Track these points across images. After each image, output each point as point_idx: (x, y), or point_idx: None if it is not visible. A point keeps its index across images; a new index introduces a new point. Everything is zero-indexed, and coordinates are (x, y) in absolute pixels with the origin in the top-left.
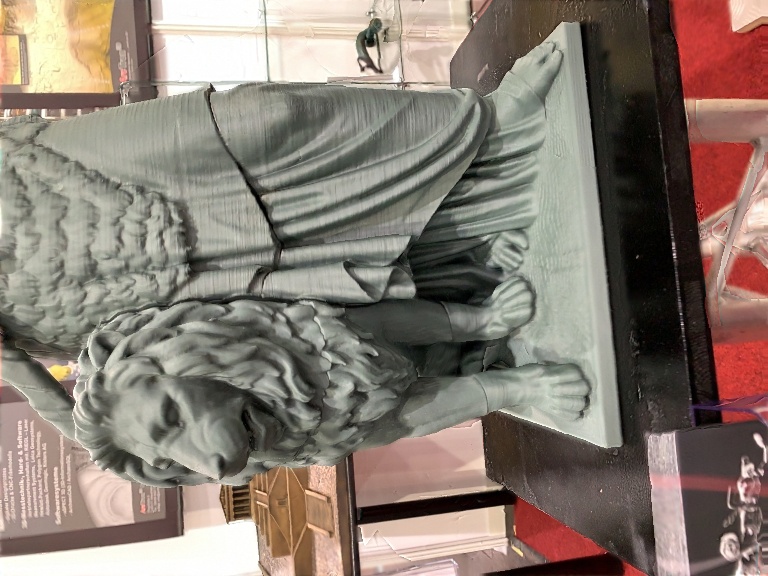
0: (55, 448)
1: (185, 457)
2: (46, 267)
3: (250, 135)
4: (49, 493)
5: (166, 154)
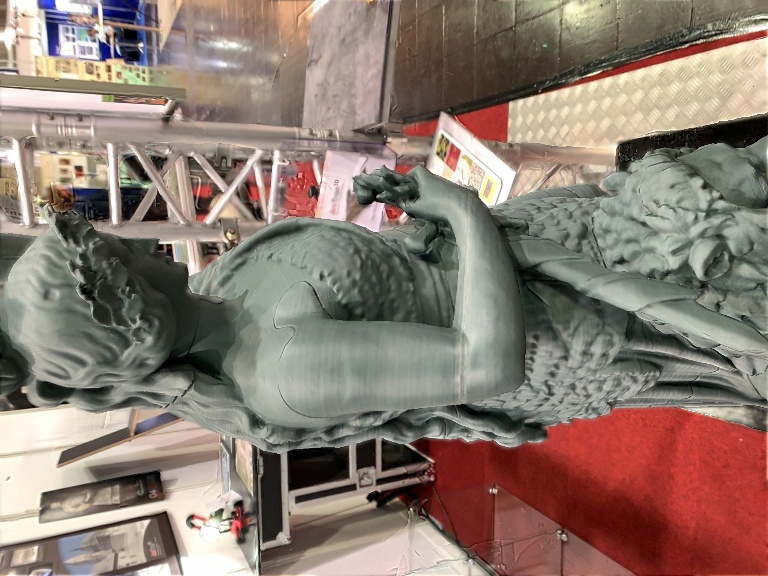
0: None
1: (767, 140)
2: (525, 204)
3: (582, 187)
4: None
5: (544, 195)
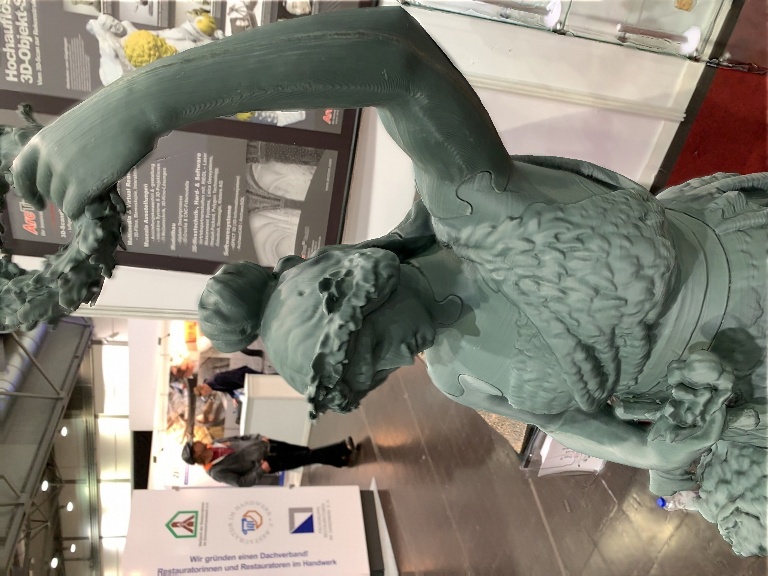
0: (231, 188)
1: None
2: None
3: None
4: (221, 227)
5: None
